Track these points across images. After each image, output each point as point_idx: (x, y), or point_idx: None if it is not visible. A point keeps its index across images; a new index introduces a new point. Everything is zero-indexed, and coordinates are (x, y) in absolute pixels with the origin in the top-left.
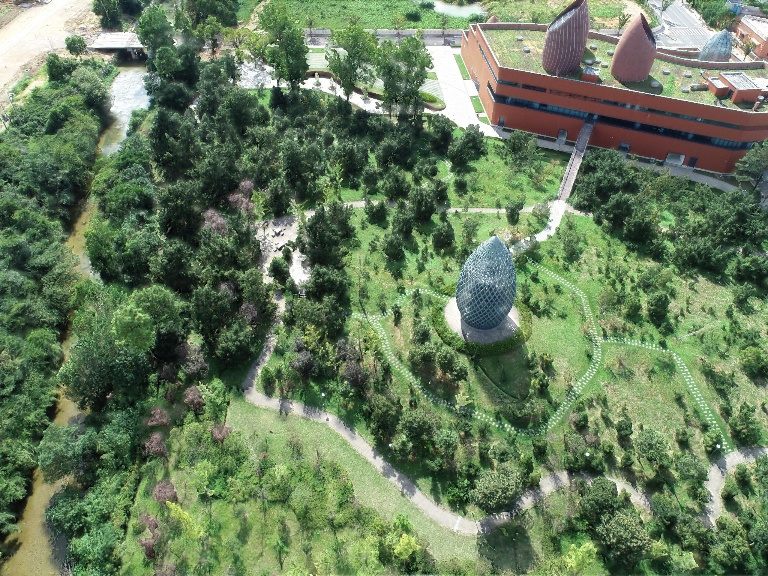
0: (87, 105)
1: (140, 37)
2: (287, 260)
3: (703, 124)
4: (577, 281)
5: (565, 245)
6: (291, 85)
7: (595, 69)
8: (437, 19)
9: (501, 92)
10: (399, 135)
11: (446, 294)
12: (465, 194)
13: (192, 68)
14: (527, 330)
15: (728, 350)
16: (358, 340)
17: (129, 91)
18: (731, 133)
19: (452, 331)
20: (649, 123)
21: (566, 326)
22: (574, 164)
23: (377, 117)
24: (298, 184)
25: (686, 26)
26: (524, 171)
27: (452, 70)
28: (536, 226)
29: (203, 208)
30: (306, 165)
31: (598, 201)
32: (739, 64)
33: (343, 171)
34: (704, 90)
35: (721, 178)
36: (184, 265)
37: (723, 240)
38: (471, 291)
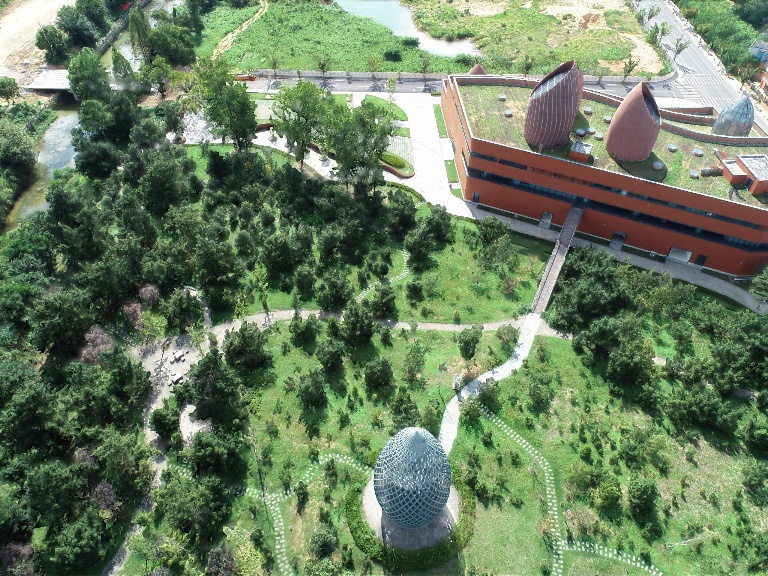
0: (4, 163)
1: (71, 83)
2: (180, 401)
3: (714, 220)
4: (542, 444)
5: (531, 391)
6: (238, 144)
7: (586, 145)
8: (420, 59)
9: (475, 165)
10: (346, 222)
11: (369, 465)
12: (419, 302)
13: (128, 120)
14: (467, 530)
15: (733, 568)
16: (246, 536)
17: (62, 142)
18: (749, 232)
19: (369, 527)
20: (649, 213)
21: (520, 520)
22: (555, 263)
23: (333, 185)
24: (211, 291)
25: (703, 73)
26: (495, 268)
27: (428, 125)
28: (499, 355)
29: (89, 324)
30: (224, 266)
31: (579, 321)
32: (761, 140)
33: (275, 267)
34: (717, 175)
35: (735, 282)
36: (39, 417)
37: (733, 386)
38: (387, 492)
